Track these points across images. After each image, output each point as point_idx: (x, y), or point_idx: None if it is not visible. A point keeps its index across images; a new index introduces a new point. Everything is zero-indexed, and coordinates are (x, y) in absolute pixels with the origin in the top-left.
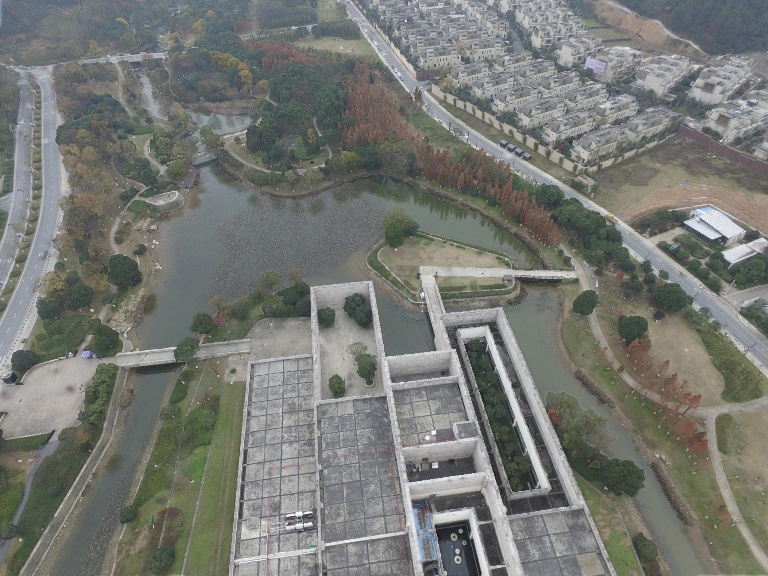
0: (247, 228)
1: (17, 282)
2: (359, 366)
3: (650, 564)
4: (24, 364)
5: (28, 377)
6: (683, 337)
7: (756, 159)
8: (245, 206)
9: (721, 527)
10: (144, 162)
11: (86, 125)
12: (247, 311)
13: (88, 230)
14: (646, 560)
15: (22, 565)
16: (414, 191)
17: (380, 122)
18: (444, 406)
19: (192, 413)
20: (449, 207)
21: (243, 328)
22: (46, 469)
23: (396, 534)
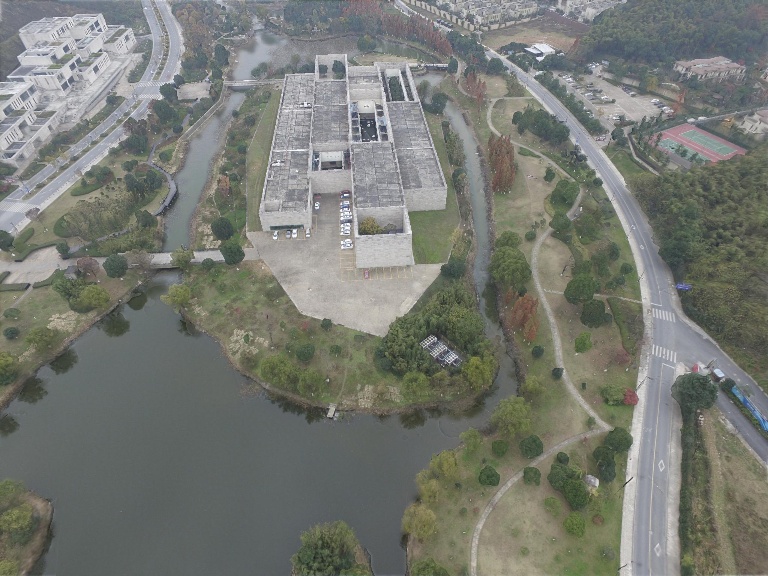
0: (284, 51)
1: (166, 62)
2: (336, 75)
3: (445, 127)
4: (180, 80)
5: (181, 87)
6: (498, 81)
7: (577, 22)
8: (282, 44)
9: (481, 124)
10: (225, 22)
11: (190, 3)
12: (284, 70)
13: (200, 42)
14: (444, 126)
15: (195, 122)
16: (382, 46)
17: (365, 7)
18: (370, 80)
19: (259, 96)
20: (402, 53)
21: (282, 76)
22: (198, 105)
23: (343, 104)
